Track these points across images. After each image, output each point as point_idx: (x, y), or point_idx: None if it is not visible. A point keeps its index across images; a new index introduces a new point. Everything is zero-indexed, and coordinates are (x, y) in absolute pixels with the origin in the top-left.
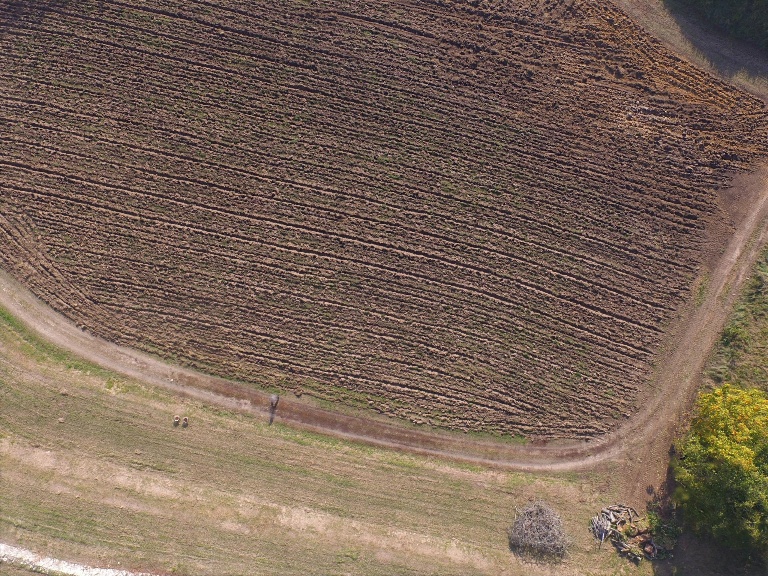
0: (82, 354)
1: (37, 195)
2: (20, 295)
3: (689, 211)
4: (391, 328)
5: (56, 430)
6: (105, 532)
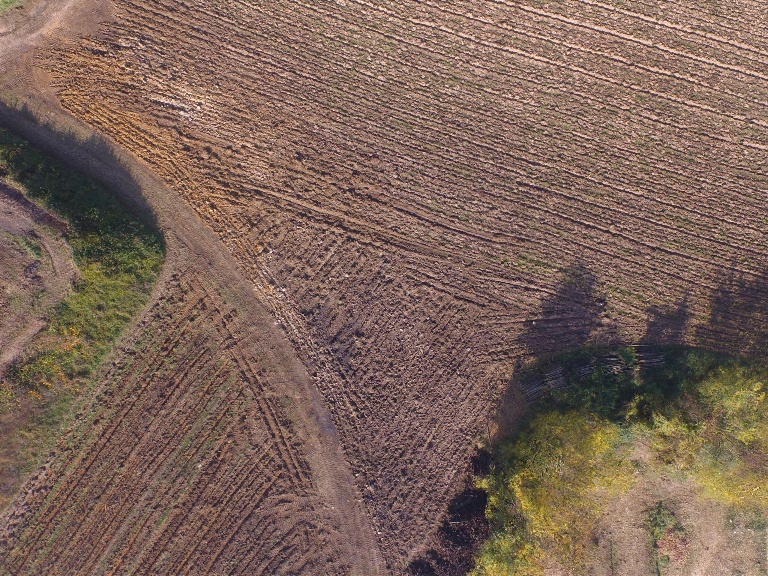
0: None
1: None
2: None
3: (145, 3)
4: None
5: None
6: None
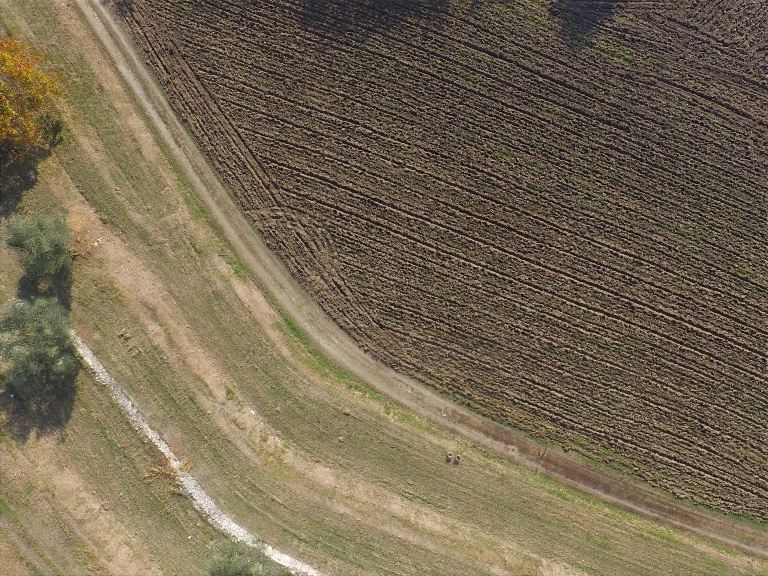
0: (361, 375)
1: (340, 212)
2: (308, 307)
3: None
4: (668, 399)
5: (335, 448)
6: (381, 559)
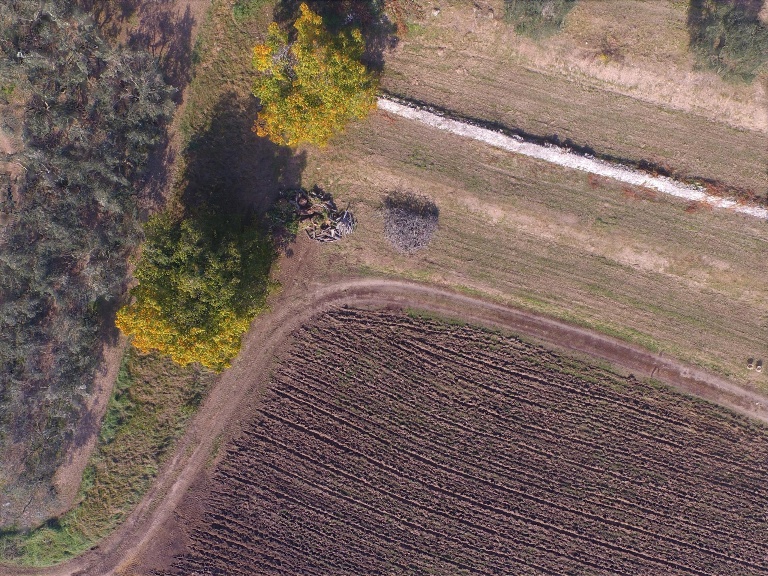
0: None
1: None
2: None
3: (219, 534)
4: (533, 437)
5: None
6: None
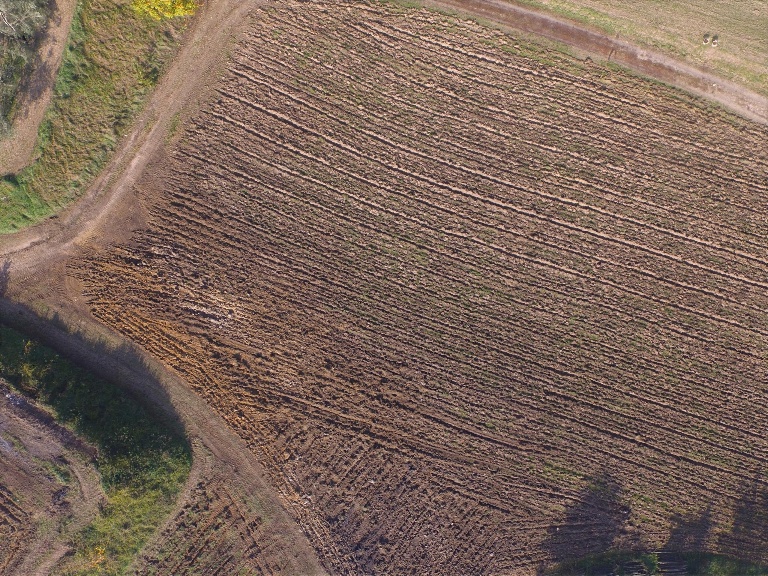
0: None
1: None
2: None
3: (179, 211)
4: (491, 119)
5: None
6: None
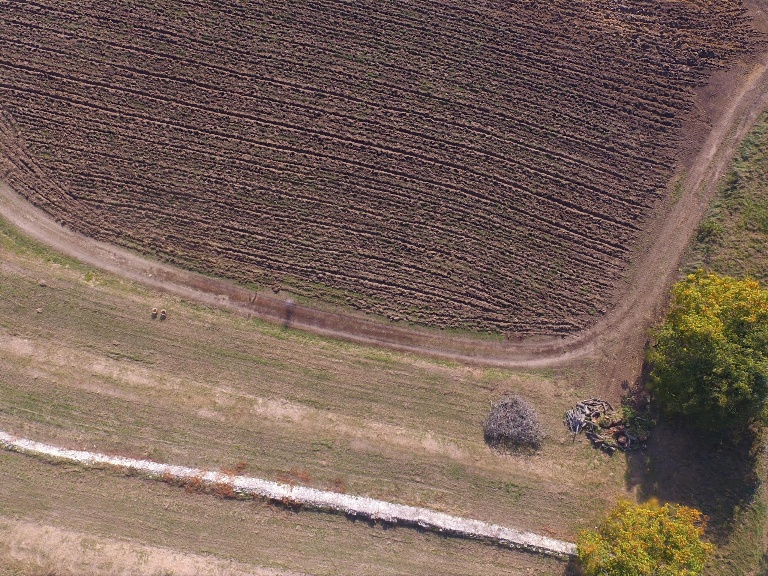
0: (61, 249)
1: (17, 91)
2: None
3: (666, 109)
4: (369, 225)
5: (34, 320)
6: (81, 416)
